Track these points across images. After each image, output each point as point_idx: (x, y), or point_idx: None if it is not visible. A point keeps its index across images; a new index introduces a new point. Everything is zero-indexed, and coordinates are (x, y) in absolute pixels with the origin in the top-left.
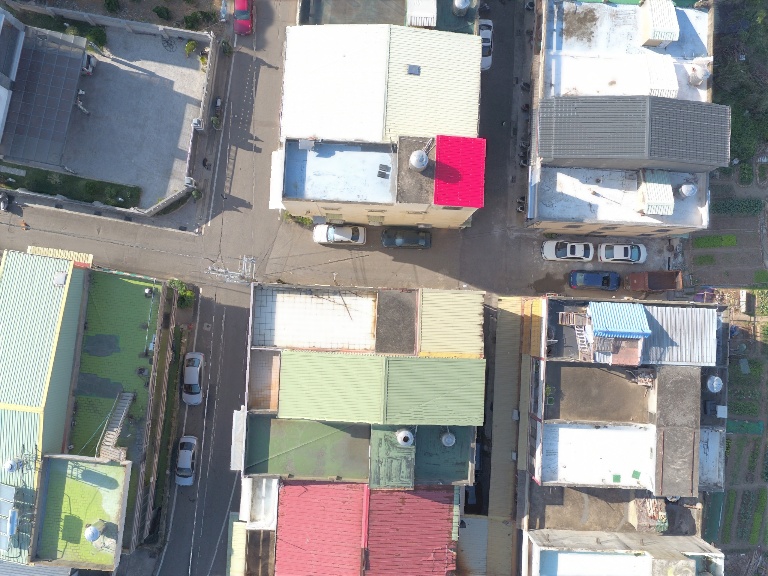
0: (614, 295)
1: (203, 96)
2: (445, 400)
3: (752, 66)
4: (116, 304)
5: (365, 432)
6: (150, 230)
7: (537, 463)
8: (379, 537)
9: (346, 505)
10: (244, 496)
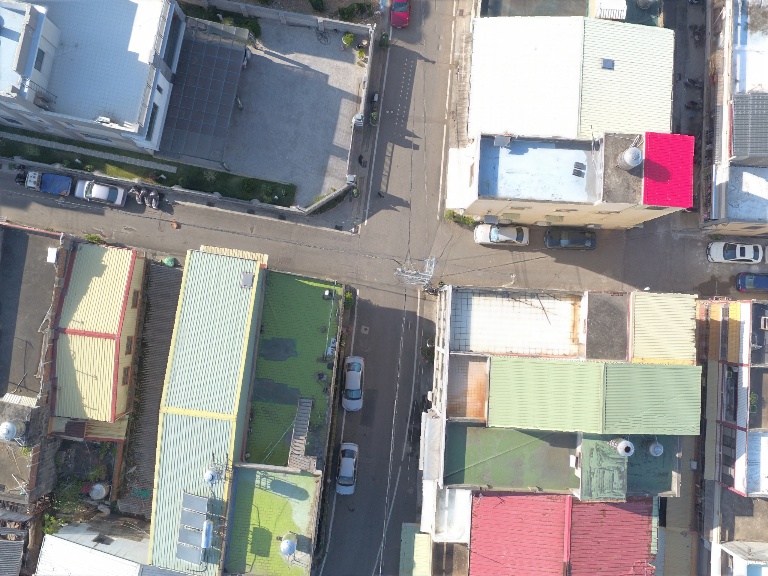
0: None
1: (364, 91)
2: (663, 408)
3: None
4: (293, 306)
5: (564, 441)
6: (305, 229)
7: (739, 473)
8: (581, 550)
9: (547, 517)
10: (426, 507)
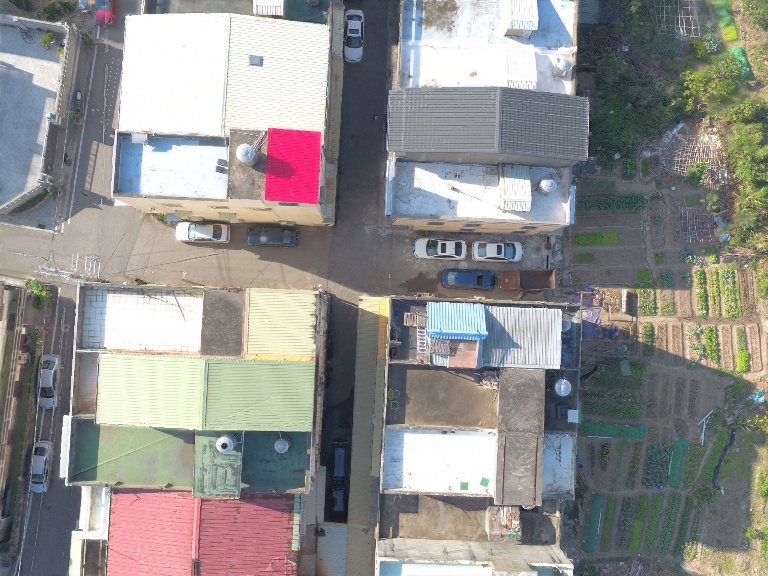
0: (489, 295)
1: (58, 89)
2: (269, 405)
3: (635, 57)
4: None
5: None
6: (7, 228)
7: None
8: (211, 547)
9: (177, 514)
10: (84, 504)
